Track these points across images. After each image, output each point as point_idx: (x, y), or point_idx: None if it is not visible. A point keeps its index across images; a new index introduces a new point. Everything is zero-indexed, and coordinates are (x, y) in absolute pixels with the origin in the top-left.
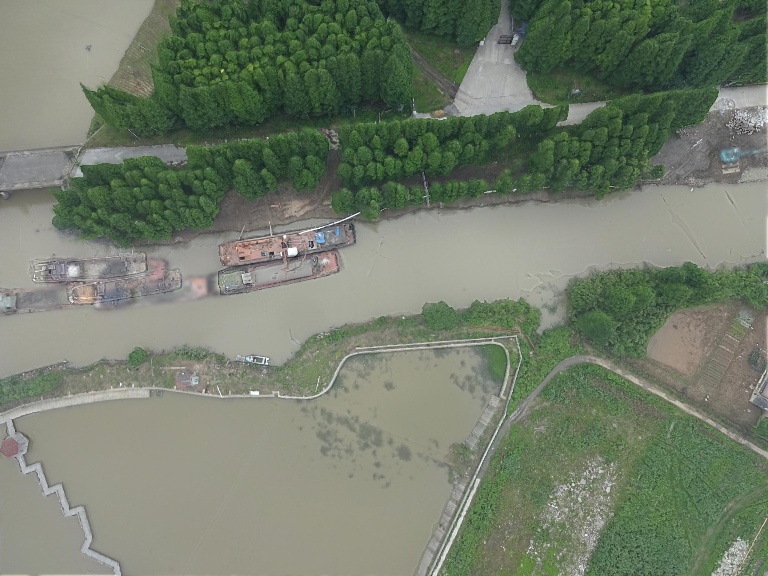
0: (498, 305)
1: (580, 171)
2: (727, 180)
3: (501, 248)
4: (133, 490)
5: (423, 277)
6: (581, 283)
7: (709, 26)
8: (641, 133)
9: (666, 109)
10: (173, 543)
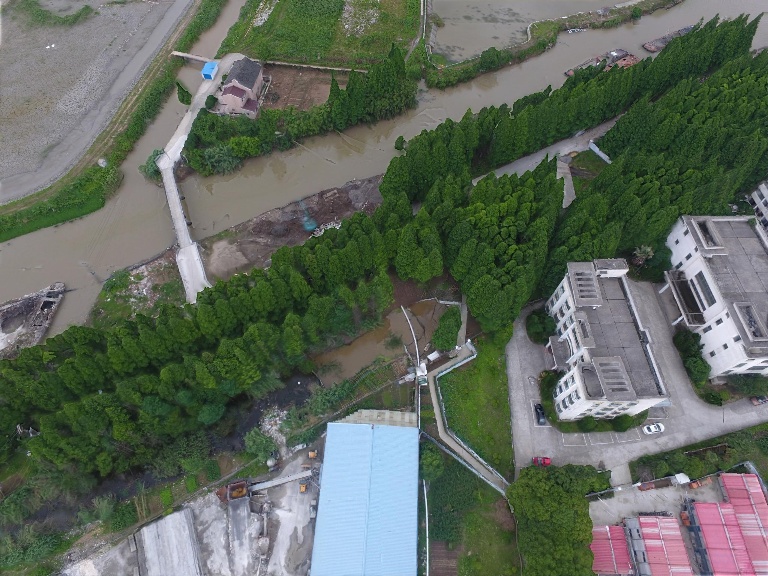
0: (459, 77)
1: None
2: None
3: None
4: None
5: (510, 94)
6: None
7: None
8: None
9: None
10: None
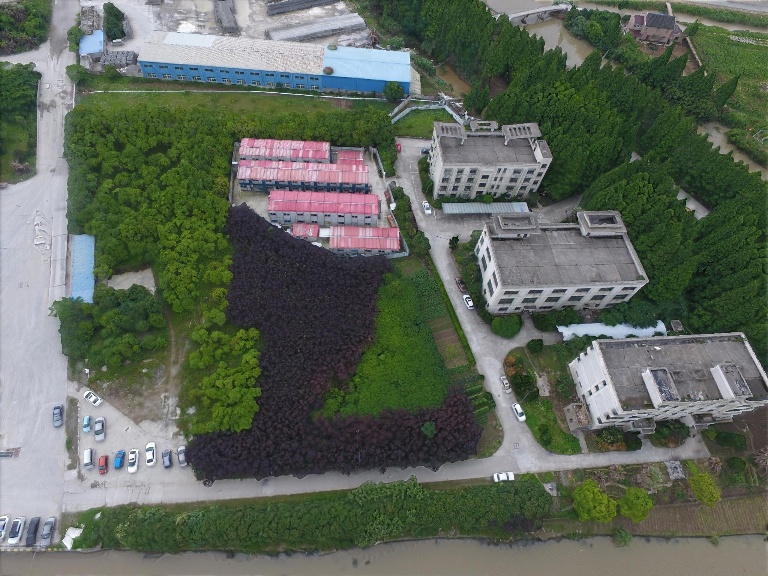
0: (751, 148)
1: None
2: None
3: None
4: None
5: None
6: (703, 112)
7: None
8: None
9: None
10: None
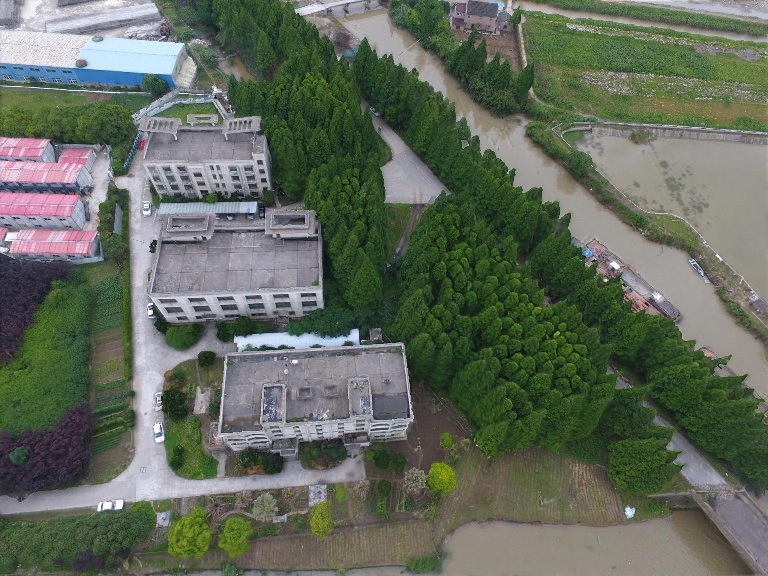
0: (543, 141)
1: None
2: None
3: None
4: None
5: (550, 197)
6: (500, 103)
7: None
8: None
9: (387, 61)
10: None
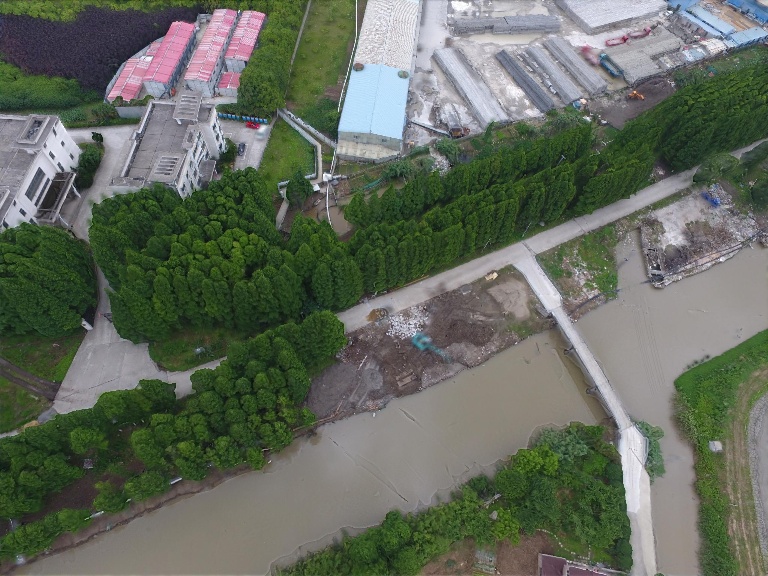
0: None
1: (204, 450)
2: (407, 391)
3: (165, 570)
4: None
5: None
6: None
7: (306, 251)
8: (258, 383)
9: (278, 348)
10: None
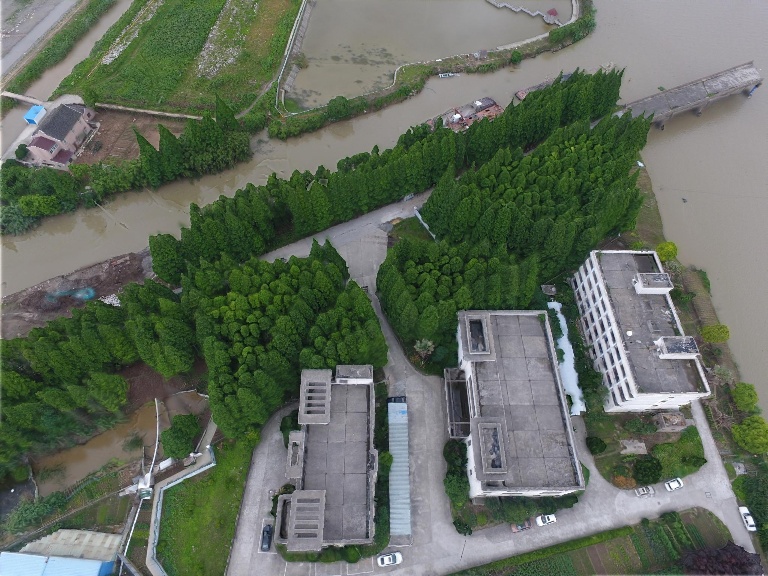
0: (302, 127)
1: None
2: None
3: None
4: (479, 18)
5: (361, 145)
6: (244, 146)
7: None
8: None
9: None
10: (445, 4)
